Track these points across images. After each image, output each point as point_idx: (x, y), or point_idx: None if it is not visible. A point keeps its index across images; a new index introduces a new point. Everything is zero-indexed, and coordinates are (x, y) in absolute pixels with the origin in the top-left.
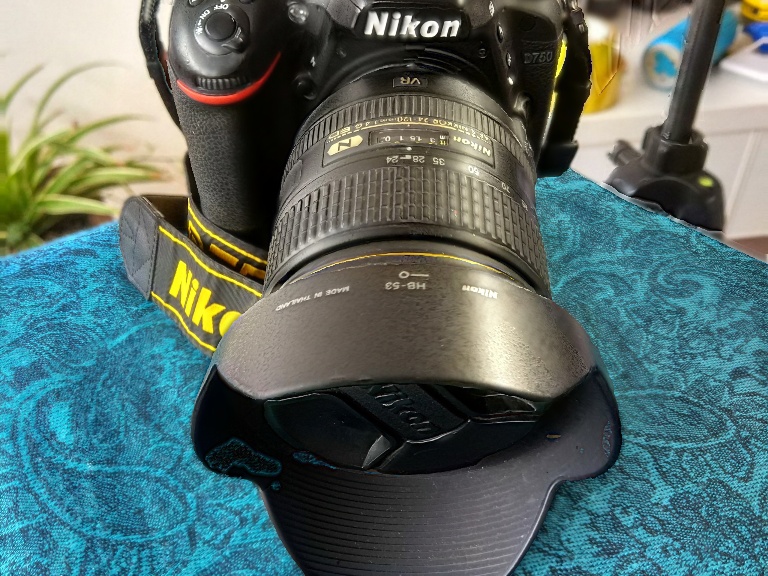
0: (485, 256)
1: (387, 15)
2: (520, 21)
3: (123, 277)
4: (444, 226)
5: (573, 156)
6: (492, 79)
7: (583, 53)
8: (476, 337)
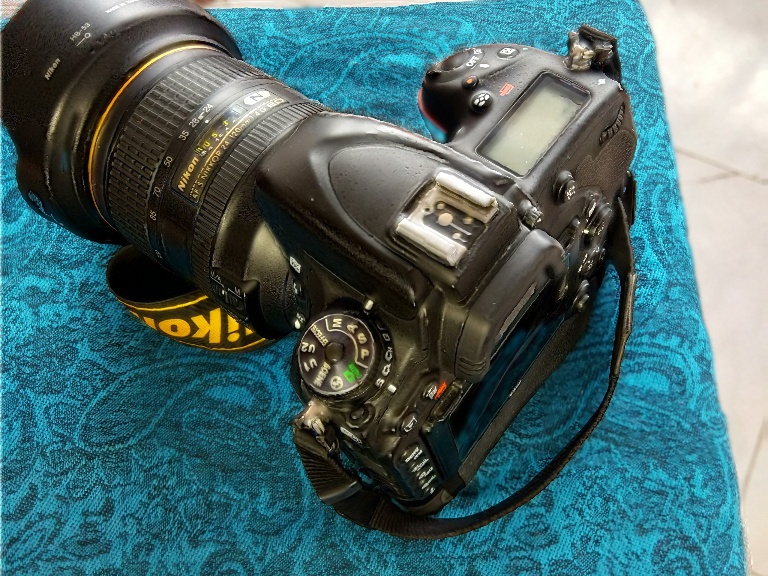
0: None
1: None
2: None
3: None
4: (135, 109)
5: None
6: None
7: None
8: (27, 45)
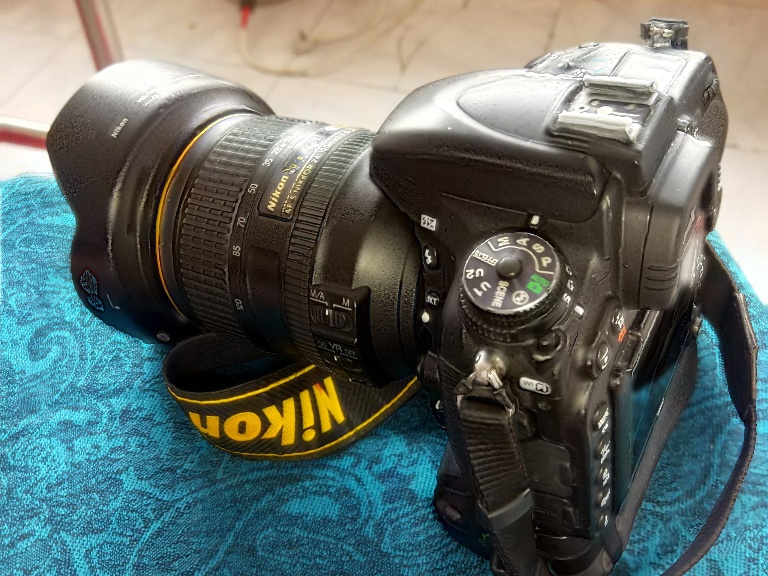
0: None
1: None
2: None
3: None
4: None
5: None
6: None
7: None
8: (91, 113)
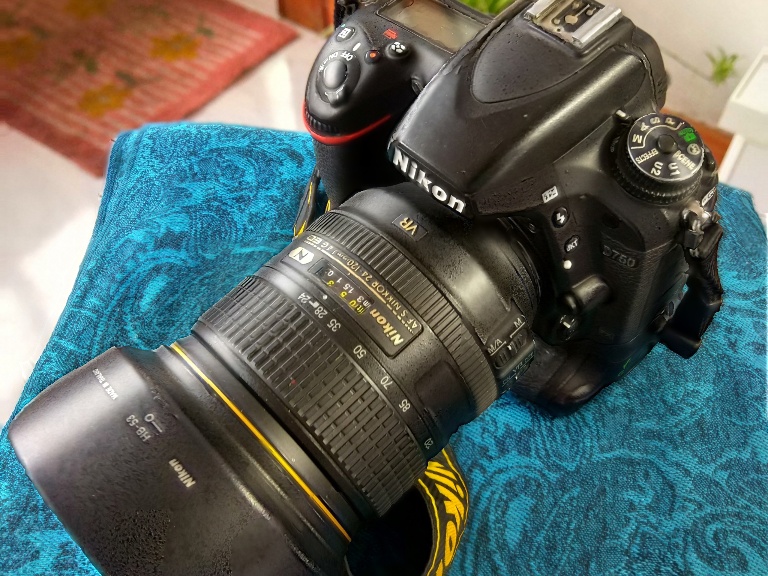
0: (287, 433)
1: (408, 159)
2: (604, 214)
3: (299, 196)
4: (270, 388)
5: (692, 352)
6: (544, 253)
7: (700, 274)
8: (125, 507)
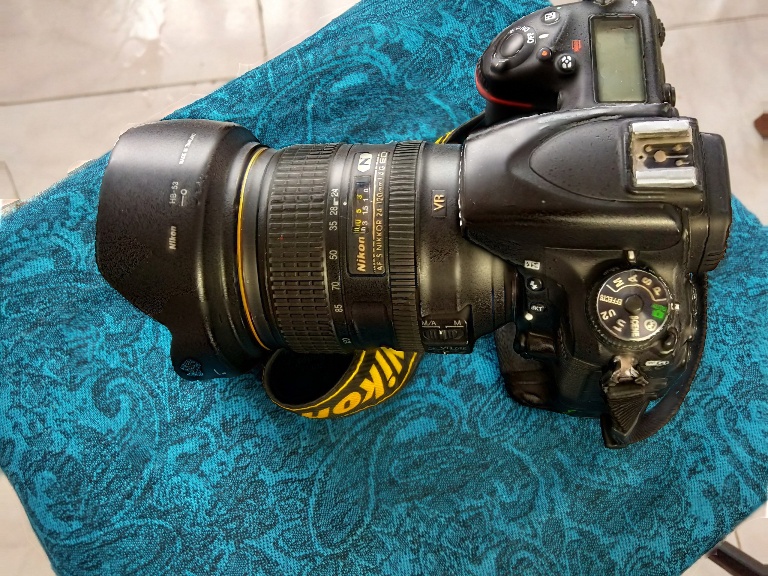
0: (257, 264)
1: None
2: None
3: None
4: (267, 230)
5: None
6: None
7: None
8: (132, 231)
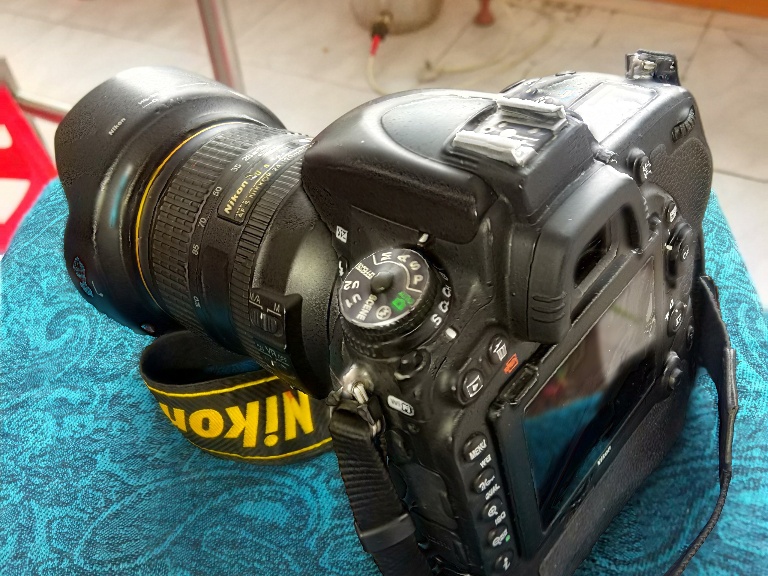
0: None
1: None
2: None
3: None
4: None
5: None
6: None
7: None
8: (97, 111)
